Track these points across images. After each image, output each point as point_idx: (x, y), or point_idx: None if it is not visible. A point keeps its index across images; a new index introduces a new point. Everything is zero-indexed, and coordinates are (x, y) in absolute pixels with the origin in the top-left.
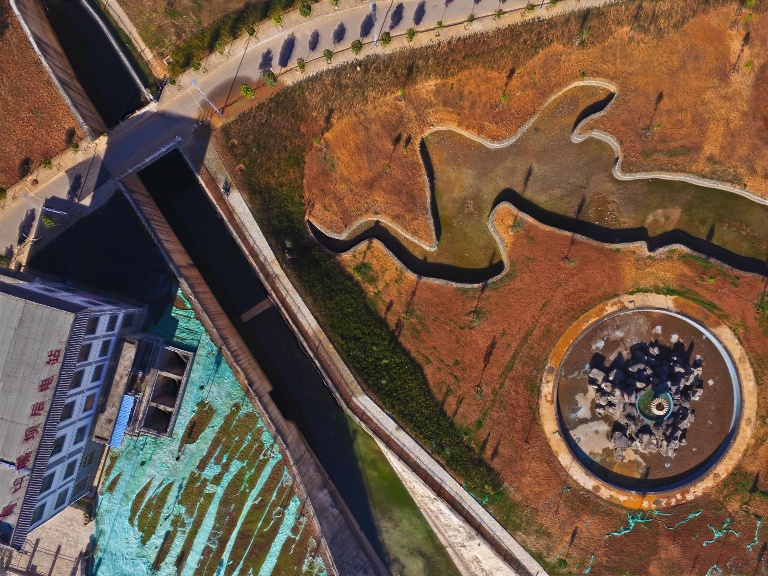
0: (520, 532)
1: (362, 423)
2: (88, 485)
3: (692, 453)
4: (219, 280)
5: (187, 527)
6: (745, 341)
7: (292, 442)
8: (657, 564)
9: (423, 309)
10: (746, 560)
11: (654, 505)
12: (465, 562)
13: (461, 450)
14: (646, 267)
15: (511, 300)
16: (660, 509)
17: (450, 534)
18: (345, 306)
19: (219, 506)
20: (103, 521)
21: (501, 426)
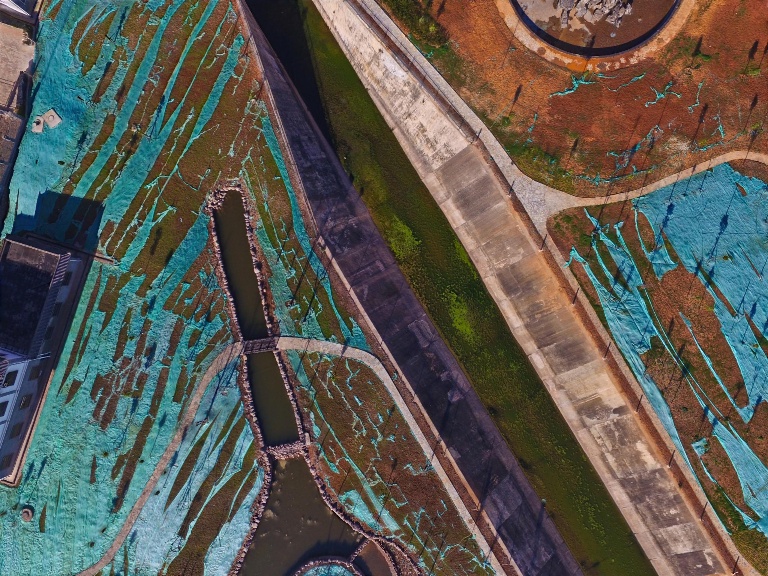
0: (464, 88)
1: None
2: (29, 4)
3: (637, 24)
4: None
5: (129, 60)
6: None
7: None
8: (599, 124)
9: None
10: (687, 121)
11: (598, 68)
12: (411, 139)
13: (407, 2)
14: None
15: None
16: (604, 72)
17: (396, 106)
18: None
19: (162, 39)
20: (43, 47)
21: None
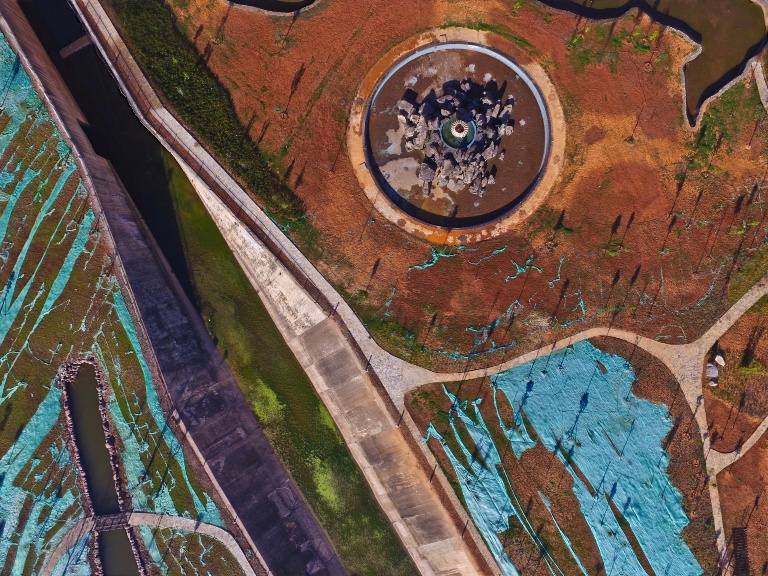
0: (321, 261)
1: (159, 136)
2: None
3: (501, 193)
4: (53, 36)
5: None
6: (555, 78)
7: (93, 161)
8: (459, 299)
9: (233, 35)
10: (548, 297)
11: (459, 241)
12: (274, 304)
13: (264, 175)
14: (458, 0)
15: (322, 29)
16: (465, 245)
17: (258, 272)
18: (151, 23)
19: (11, 216)
20: None
21: (306, 154)
